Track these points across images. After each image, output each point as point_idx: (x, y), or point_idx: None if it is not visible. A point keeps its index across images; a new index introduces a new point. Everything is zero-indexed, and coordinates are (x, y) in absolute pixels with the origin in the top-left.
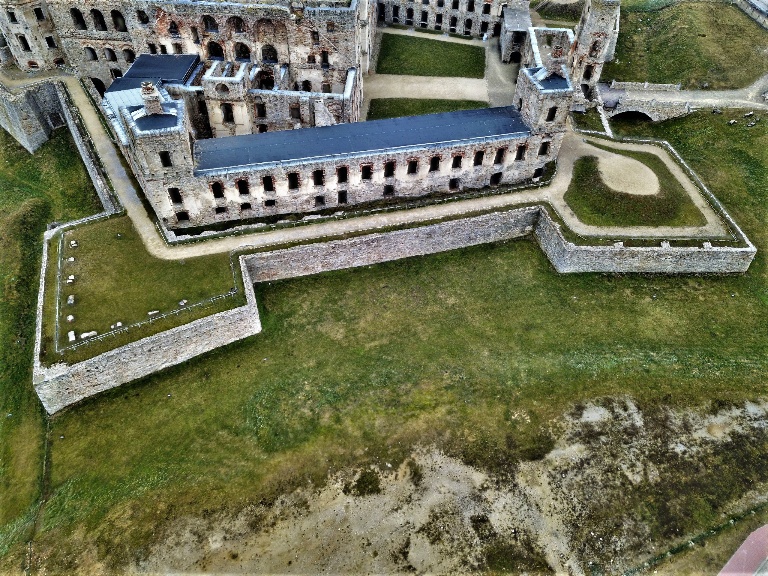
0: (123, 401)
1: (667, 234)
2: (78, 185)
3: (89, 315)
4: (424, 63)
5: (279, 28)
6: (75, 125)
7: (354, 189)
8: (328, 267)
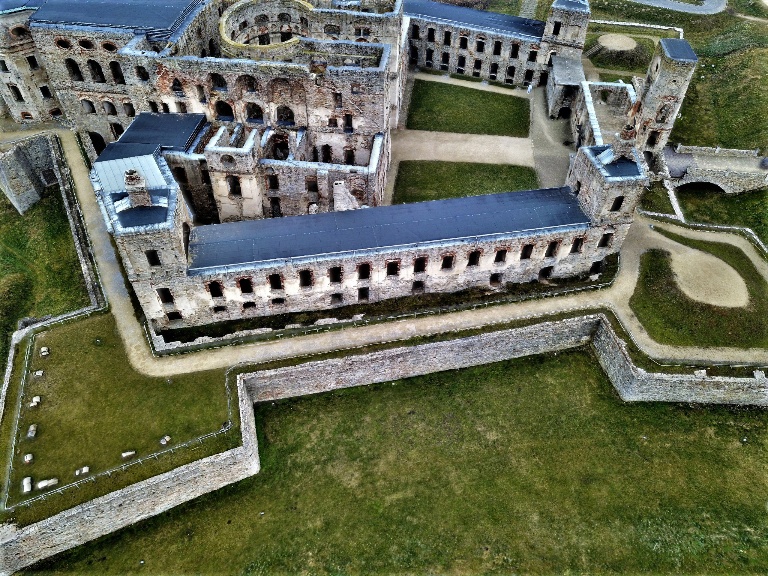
0: (86, 567)
1: (760, 360)
2: (66, 258)
3: (51, 454)
4: (460, 117)
5: (296, 88)
6: (64, 192)
7: (377, 286)
8: (344, 384)
